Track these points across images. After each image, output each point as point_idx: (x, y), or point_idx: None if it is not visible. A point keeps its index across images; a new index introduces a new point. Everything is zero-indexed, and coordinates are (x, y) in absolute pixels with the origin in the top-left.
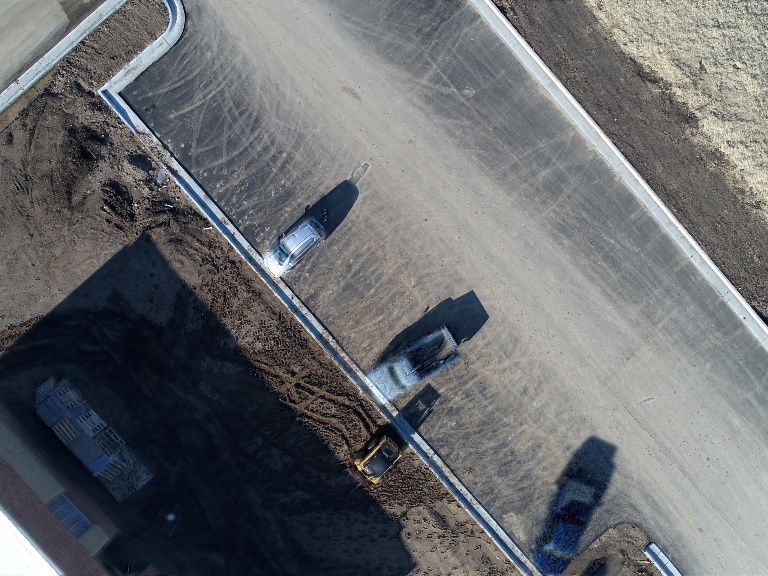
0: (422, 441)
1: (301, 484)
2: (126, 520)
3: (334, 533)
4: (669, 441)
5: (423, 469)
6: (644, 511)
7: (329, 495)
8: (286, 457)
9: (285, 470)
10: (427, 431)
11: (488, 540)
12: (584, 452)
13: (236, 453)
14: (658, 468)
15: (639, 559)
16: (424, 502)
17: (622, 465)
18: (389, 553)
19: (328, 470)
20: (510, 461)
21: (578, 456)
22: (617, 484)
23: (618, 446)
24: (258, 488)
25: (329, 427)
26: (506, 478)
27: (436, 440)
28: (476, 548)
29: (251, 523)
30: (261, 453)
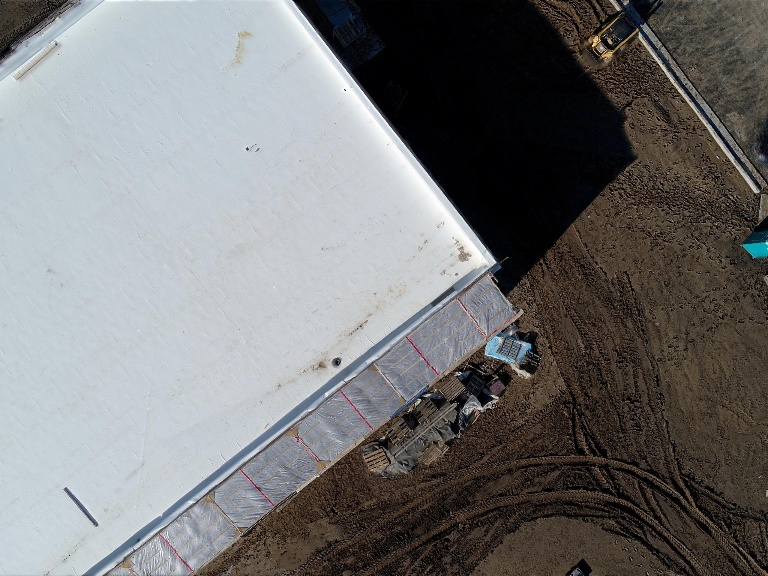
0: (651, 32)
1: (530, 65)
2: None
3: (560, 117)
4: None
5: (649, 62)
6: None
7: (557, 78)
8: (517, 37)
9: (515, 50)
10: (656, 23)
11: (709, 138)
12: None
13: (468, 29)
14: None
15: None
16: (649, 95)
17: None
18: (612, 142)
19: (557, 53)
20: (736, 60)
21: None
22: None
23: None
24: (488, 65)
25: (560, 11)
26: (731, 77)
27: (664, 33)
28: (697, 146)
29: (479, 100)
30: (493, 31)
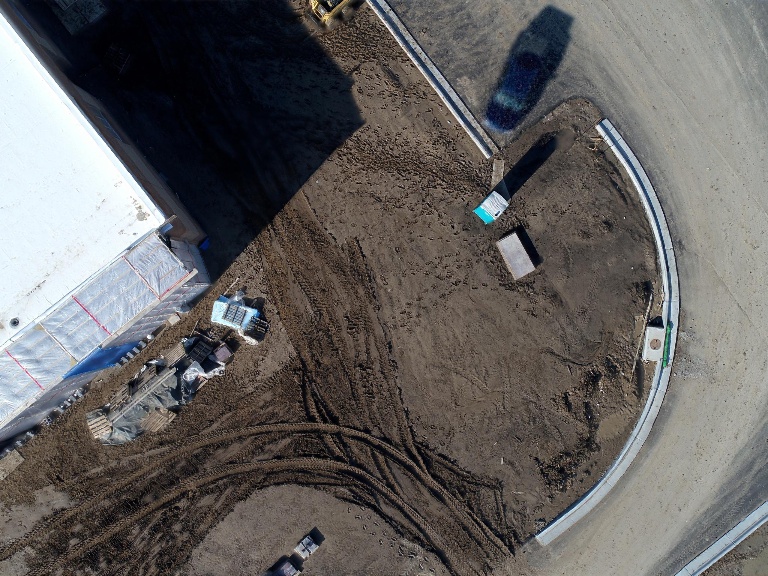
0: None
1: (255, 28)
2: (77, 52)
3: (285, 81)
4: (627, 14)
5: (378, 26)
6: (598, 85)
7: (282, 41)
8: None
9: (239, 13)
10: None
11: (440, 103)
12: (541, 20)
13: None
14: (614, 41)
15: (591, 136)
16: (378, 59)
17: (578, 36)
18: (340, 106)
19: (283, 17)
20: (466, 24)
21: (535, 24)
22: (573, 56)
23: (575, 16)
24: (211, 28)
25: None
26: (461, 41)
27: None
28: (428, 111)
29: (202, 64)
30: None
